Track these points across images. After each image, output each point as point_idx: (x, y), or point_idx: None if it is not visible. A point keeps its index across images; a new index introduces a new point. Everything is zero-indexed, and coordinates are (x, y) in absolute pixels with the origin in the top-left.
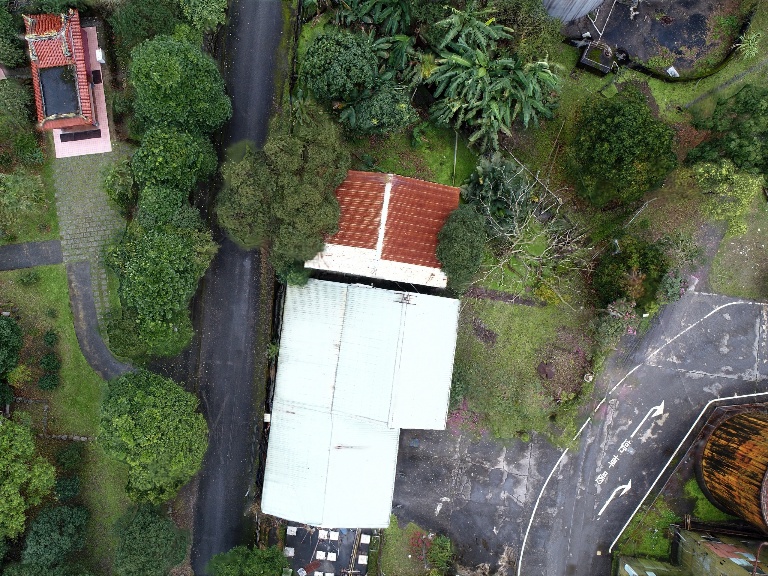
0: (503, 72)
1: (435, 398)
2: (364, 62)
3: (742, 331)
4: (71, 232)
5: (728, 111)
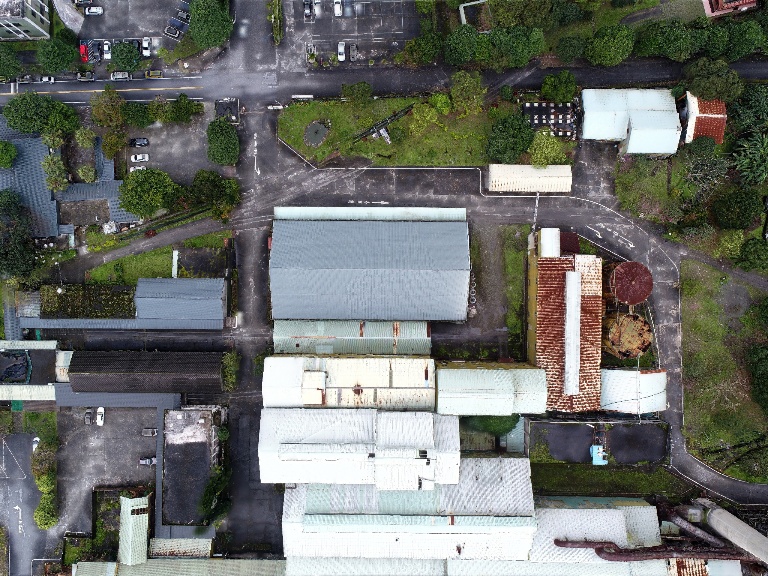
0: (763, 160)
1: (640, 147)
2: (761, 106)
3: (667, 275)
4: (673, 5)
5: (761, 242)
